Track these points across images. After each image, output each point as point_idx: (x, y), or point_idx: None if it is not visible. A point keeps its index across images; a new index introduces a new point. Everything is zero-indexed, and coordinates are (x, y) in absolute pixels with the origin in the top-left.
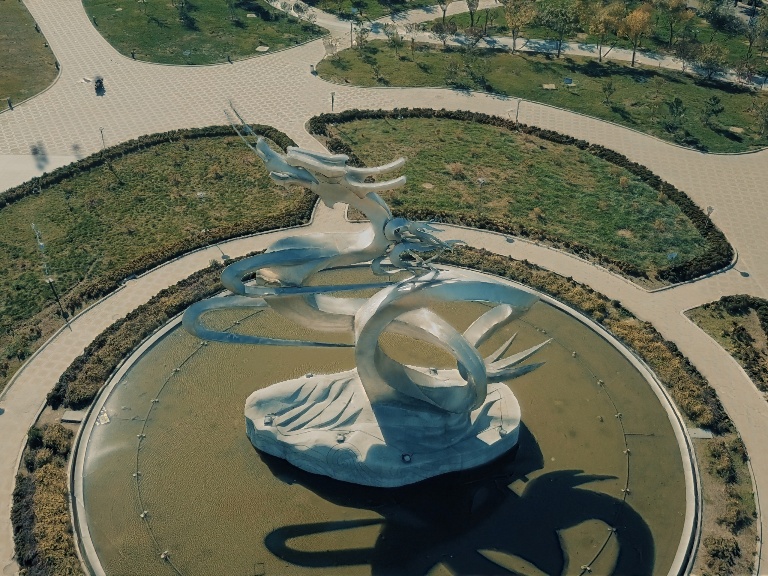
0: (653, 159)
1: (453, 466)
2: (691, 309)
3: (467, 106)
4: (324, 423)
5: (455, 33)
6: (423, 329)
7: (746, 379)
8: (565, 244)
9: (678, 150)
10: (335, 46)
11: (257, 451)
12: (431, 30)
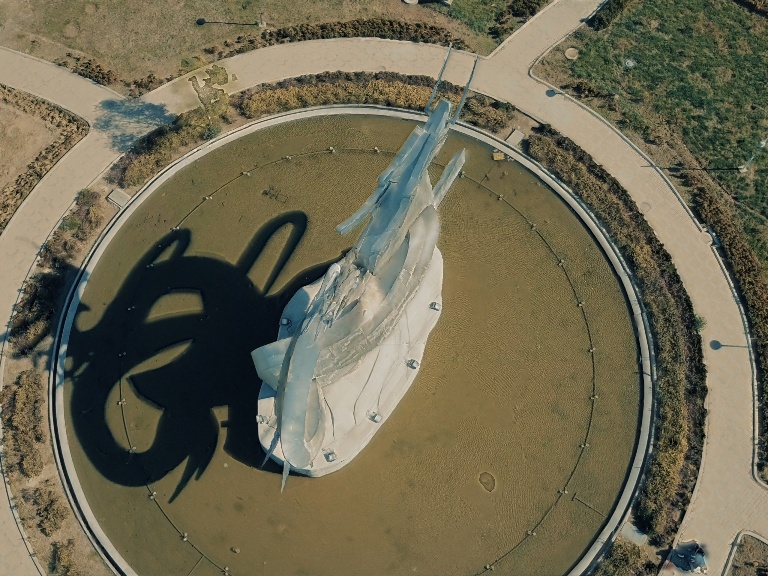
0: None
1: None
2: None
3: None
4: None
5: None
6: None
7: None
8: None
9: None
10: None
11: None
12: None
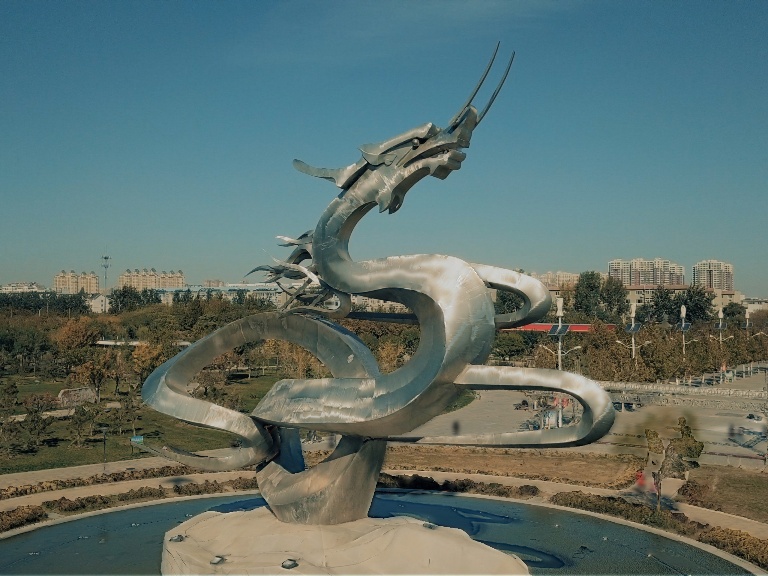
0: None
1: None
2: None
3: None
4: None
5: None
6: None
7: None
8: None
9: None
10: None
11: None
12: None
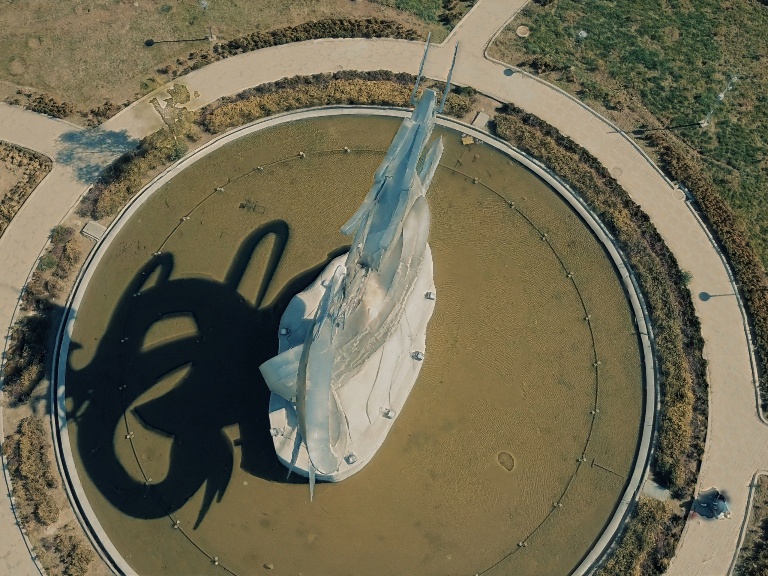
0: None
1: None
2: None
3: None
4: None
5: None
6: None
7: None
8: None
9: None
10: None
11: None
12: None
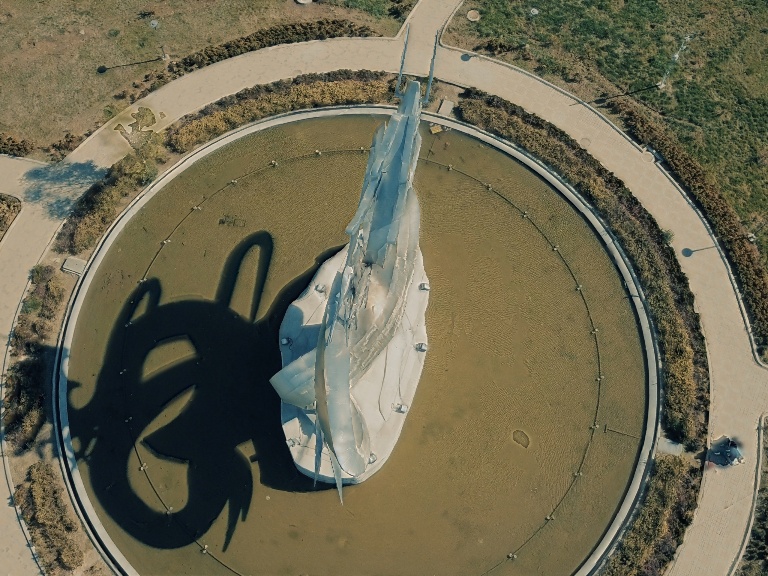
0: None
1: None
2: None
3: None
4: None
5: None
6: None
7: None
8: None
9: None
10: None
11: None
12: None
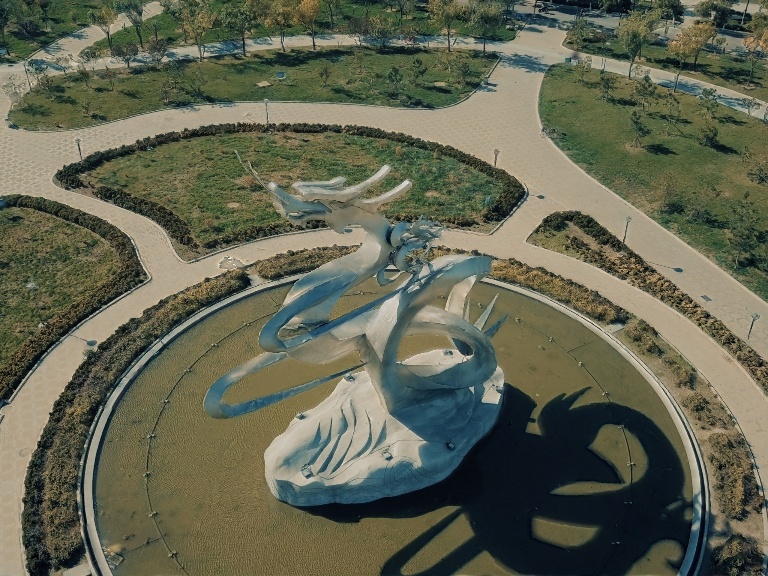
0: (400, 125)
1: (478, 436)
2: (529, 237)
3: (203, 121)
4: (361, 450)
5: (136, 53)
6: (427, 322)
7: (607, 275)
8: (396, 218)
9: (412, 113)
10: (19, 93)
11: (301, 509)
12: (111, 55)
